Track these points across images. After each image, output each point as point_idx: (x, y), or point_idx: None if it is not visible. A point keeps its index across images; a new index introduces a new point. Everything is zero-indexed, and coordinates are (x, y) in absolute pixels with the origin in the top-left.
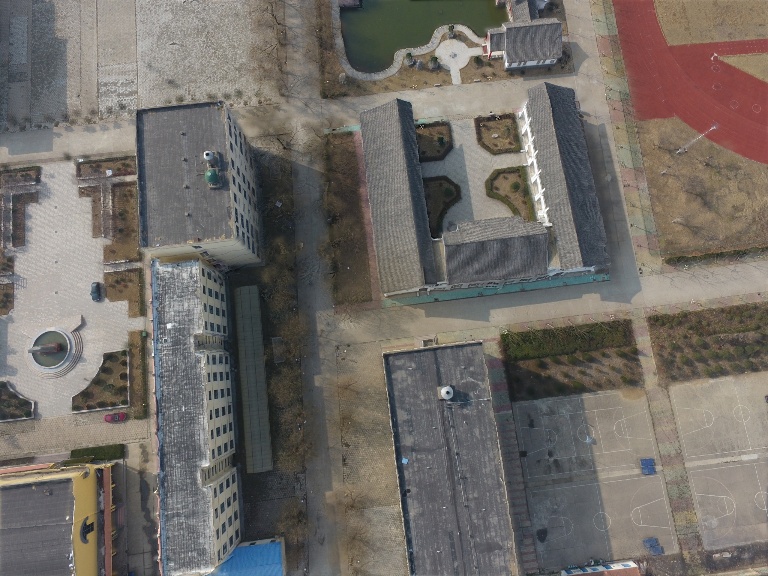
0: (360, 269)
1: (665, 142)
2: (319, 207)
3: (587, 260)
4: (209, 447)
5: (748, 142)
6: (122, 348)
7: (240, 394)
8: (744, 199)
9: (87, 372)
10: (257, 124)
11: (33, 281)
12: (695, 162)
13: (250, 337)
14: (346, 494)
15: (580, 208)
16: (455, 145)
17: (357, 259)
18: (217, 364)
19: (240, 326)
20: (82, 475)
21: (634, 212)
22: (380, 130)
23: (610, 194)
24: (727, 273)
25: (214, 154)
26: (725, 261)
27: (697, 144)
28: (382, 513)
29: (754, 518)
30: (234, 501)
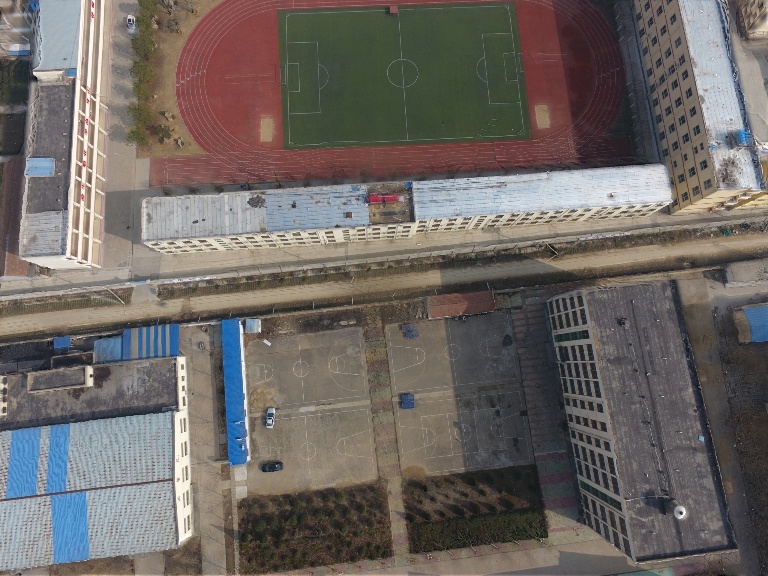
0: None
1: None
2: None
3: None
4: None
5: None
6: None
7: None
8: None
9: None
10: None
11: None
12: None
13: None
14: None
15: None
16: None
17: None
18: None
19: None
20: None
21: None
22: None
23: None
24: None
25: None
26: None
27: None
28: None
29: (313, 354)
30: None
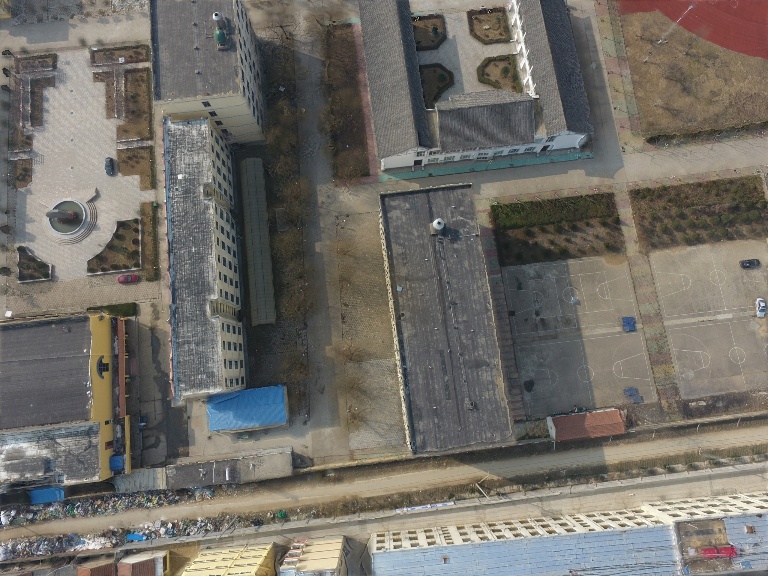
0: (358, 147)
1: (647, 33)
2: (320, 88)
3: (571, 124)
4: (217, 283)
5: (726, 34)
6: (134, 217)
7: (245, 256)
8: (721, 85)
9: (101, 239)
10: (261, 17)
11: (50, 157)
12: (675, 52)
13: (255, 203)
14: (345, 348)
15: (565, 84)
16: (449, 36)
17: (356, 138)
18: (224, 221)
19: (245, 194)
20: (98, 317)
21: (617, 97)
22: (377, 11)
23: (595, 80)
24: (705, 151)
25: (222, 18)
26: (703, 140)
27: (677, 35)
28: (379, 365)
29: (728, 371)
30: (240, 350)
